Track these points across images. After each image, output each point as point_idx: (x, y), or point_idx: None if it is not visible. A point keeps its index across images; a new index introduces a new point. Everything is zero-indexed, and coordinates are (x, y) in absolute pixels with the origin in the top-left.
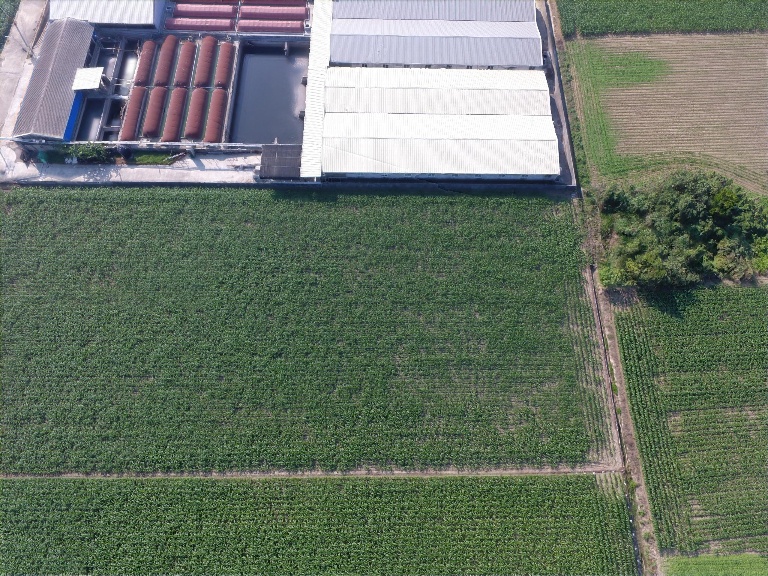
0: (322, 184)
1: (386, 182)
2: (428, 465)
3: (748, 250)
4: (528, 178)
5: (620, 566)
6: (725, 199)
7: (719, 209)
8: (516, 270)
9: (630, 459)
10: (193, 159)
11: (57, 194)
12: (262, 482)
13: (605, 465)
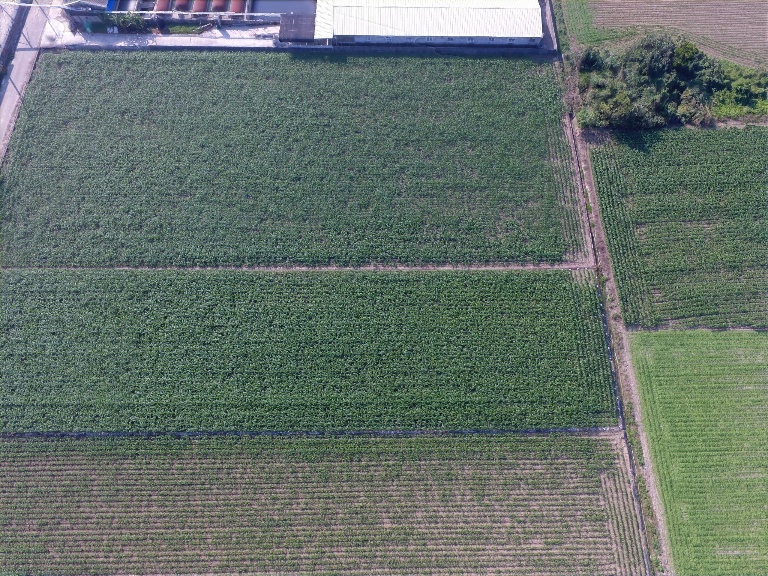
0: (333, 48)
1: (390, 46)
2: (427, 263)
3: (708, 100)
4: (515, 43)
5: (591, 335)
6: (686, 51)
7: (681, 61)
8: (504, 115)
9: (601, 260)
10: (219, 30)
11: (101, 56)
12: (285, 273)
13: (580, 264)
